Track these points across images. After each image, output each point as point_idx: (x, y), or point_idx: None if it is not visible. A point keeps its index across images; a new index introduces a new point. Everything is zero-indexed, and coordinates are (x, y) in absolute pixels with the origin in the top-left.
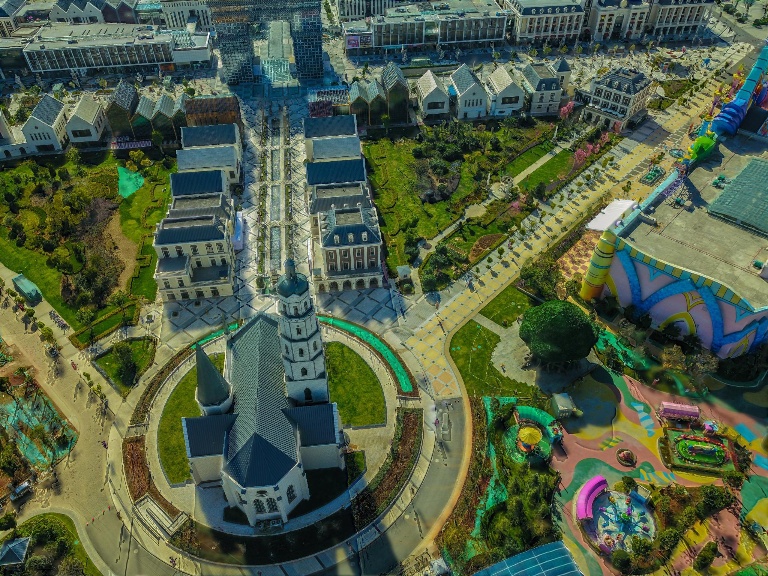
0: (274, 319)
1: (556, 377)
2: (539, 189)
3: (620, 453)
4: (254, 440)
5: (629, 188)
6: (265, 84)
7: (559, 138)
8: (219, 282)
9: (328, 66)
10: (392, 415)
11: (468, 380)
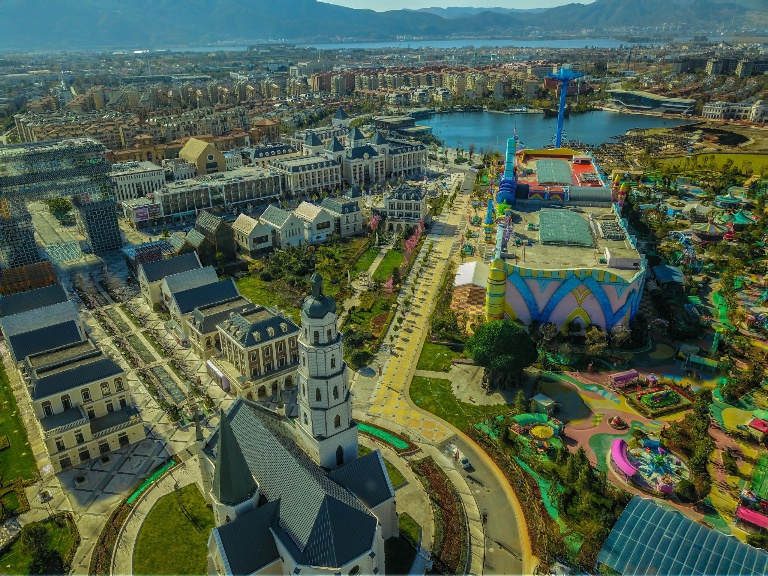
0: (254, 403)
1: (517, 391)
2: (395, 274)
3: (611, 422)
4: (328, 504)
5: (465, 254)
6: (57, 264)
7: (379, 243)
8: (129, 424)
9: (123, 238)
10: (407, 472)
11: (450, 419)
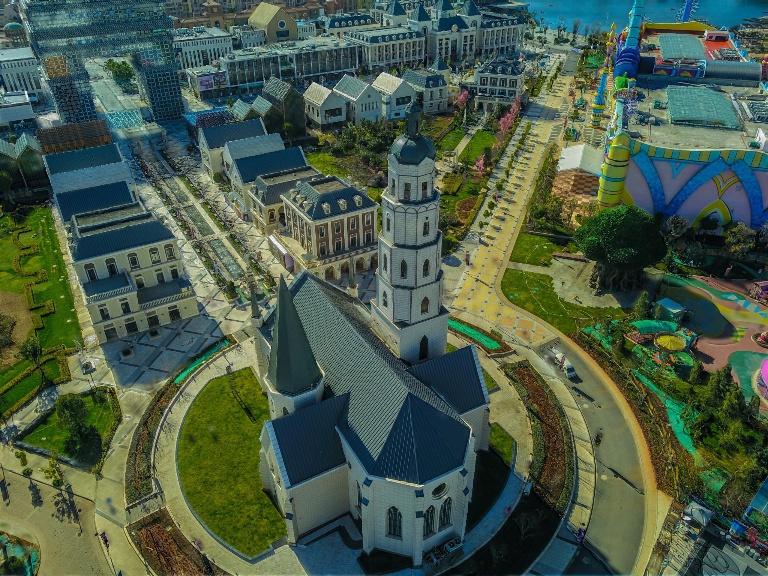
0: None
1: (635, 294)
2: (486, 155)
3: (757, 338)
4: (411, 405)
5: (571, 136)
6: (117, 131)
7: (467, 123)
8: (180, 297)
9: (186, 107)
10: (498, 376)
11: (552, 320)
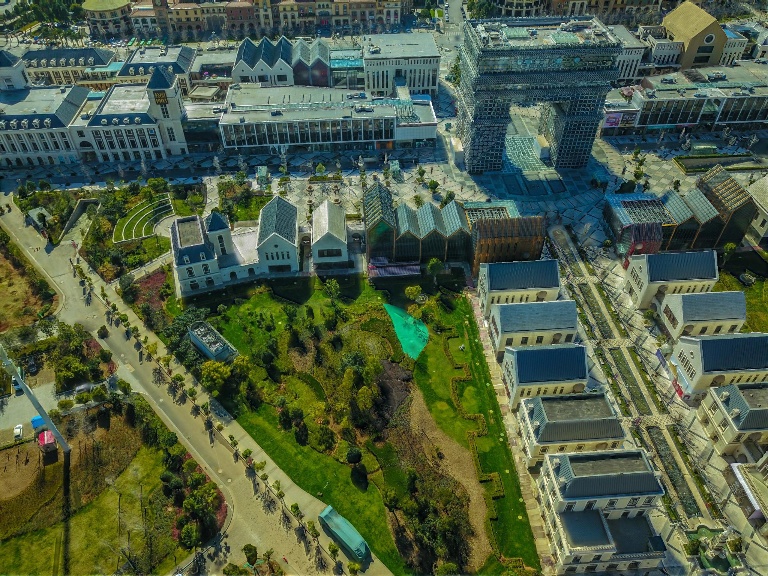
0: None
1: None
2: None
3: None
4: None
5: None
6: (516, 174)
7: None
8: (649, 555)
9: None
10: None
11: None
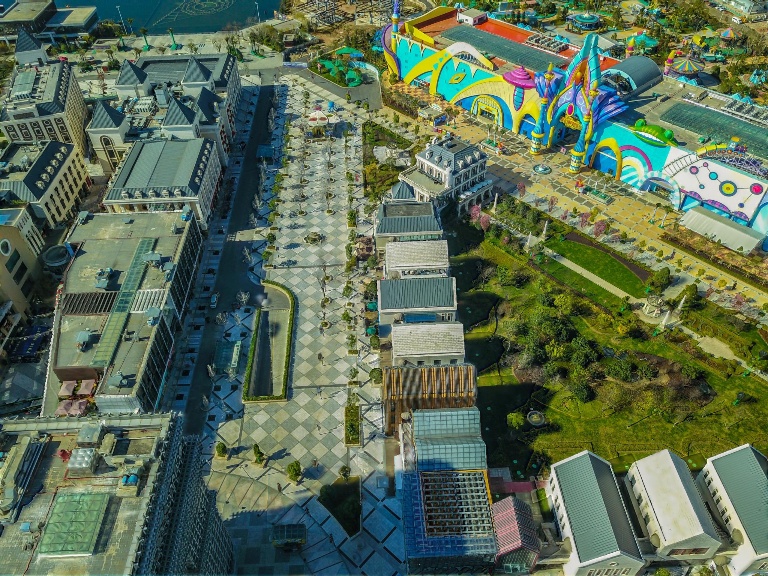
0: None
1: None
2: None
3: None
4: None
5: (669, 207)
6: None
7: None
8: None
9: None
10: None
11: None
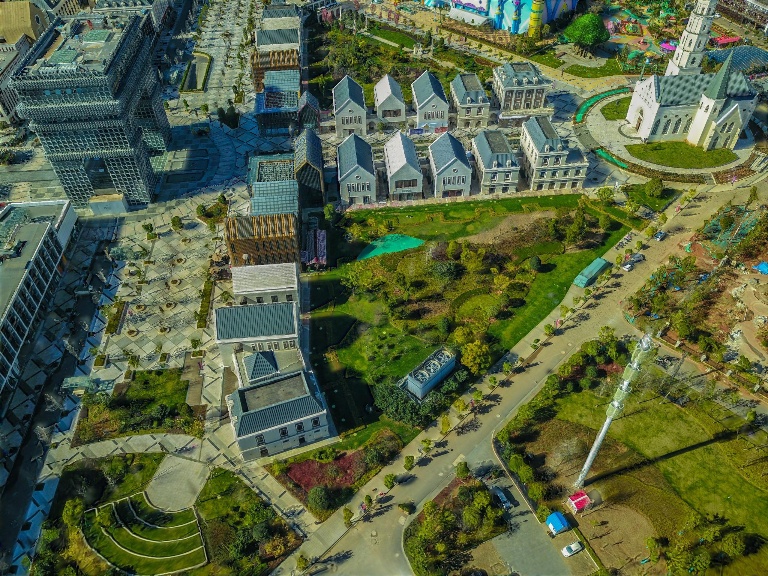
0: None
1: (599, 53)
2: (430, 37)
3: None
4: None
5: (441, 7)
6: (168, 174)
7: None
8: None
9: None
10: None
11: (612, 74)
